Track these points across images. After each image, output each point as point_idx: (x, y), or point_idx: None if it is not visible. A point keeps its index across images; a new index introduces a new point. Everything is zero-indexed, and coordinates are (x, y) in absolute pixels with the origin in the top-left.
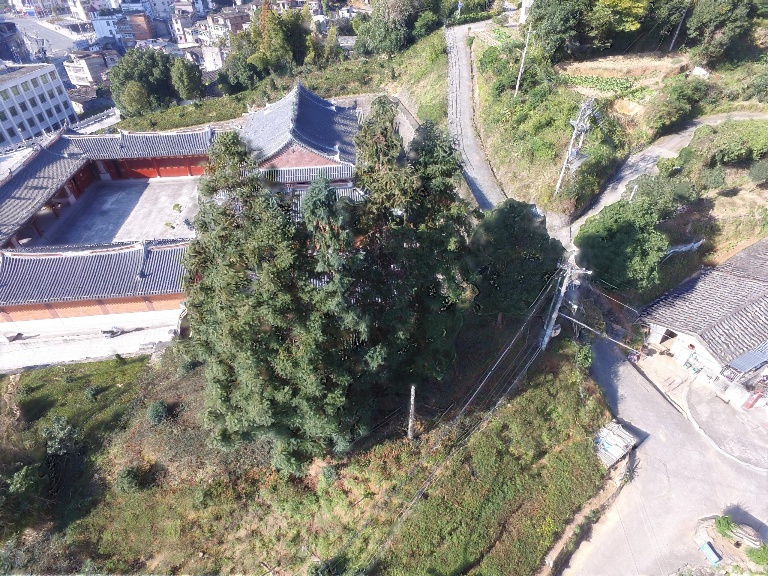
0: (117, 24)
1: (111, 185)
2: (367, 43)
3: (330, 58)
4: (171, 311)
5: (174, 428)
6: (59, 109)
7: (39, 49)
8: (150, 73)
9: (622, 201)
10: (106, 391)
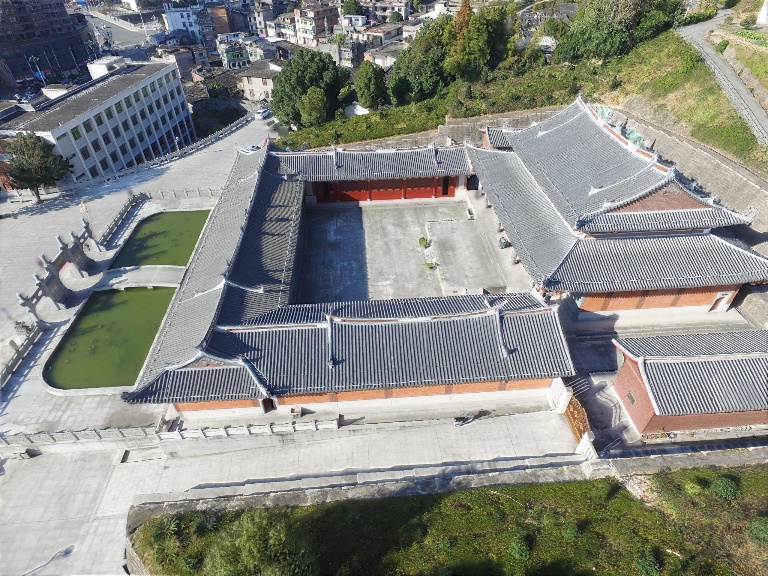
0: (198, 17)
1: (319, 209)
2: (577, 46)
3: (527, 62)
4: (523, 391)
5: None
6: (177, 111)
7: (110, 42)
8: (319, 77)
9: None
10: (667, 564)
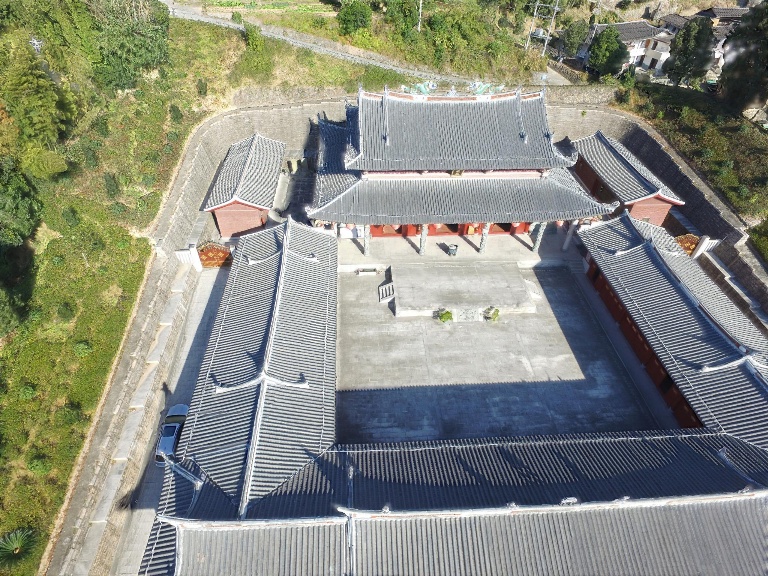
0: None
1: None
2: None
3: None
4: None
5: None
6: None
7: None
8: None
9: (608, 30)
10: None
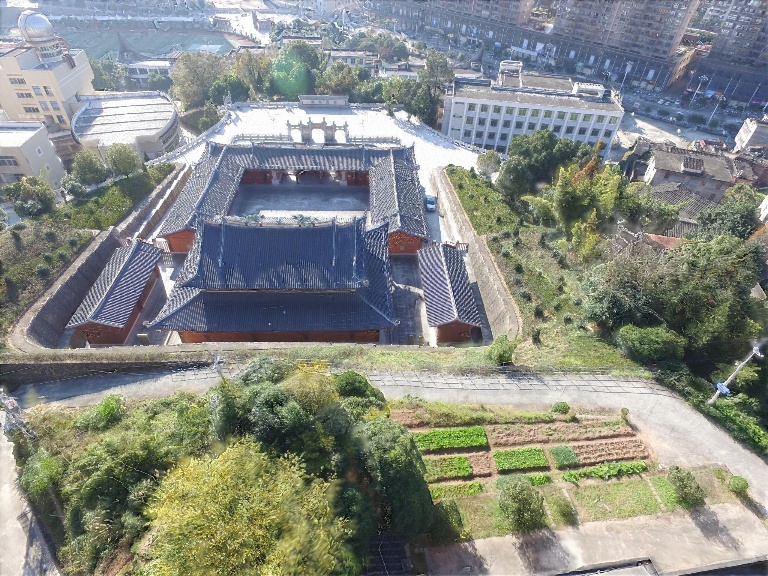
0: None
1: None
2: None
3: None
4: None
5: (4, 231)
6: (592, 146)
7: None
8: None
9: None
10: (64, 216)
